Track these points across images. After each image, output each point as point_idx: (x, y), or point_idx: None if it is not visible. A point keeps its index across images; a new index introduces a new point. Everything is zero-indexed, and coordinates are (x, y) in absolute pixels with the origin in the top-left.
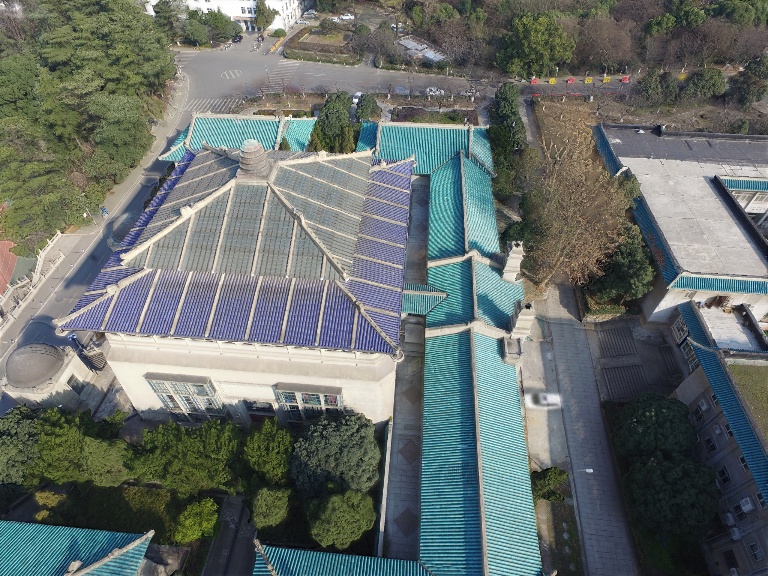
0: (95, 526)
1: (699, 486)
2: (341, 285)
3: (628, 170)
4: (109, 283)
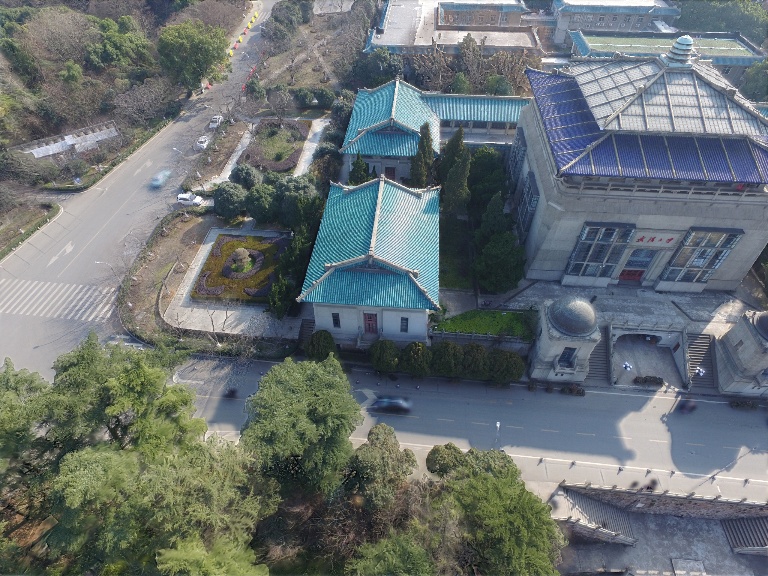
0: None
1: None
2: None
3: (439, 44)
4: None
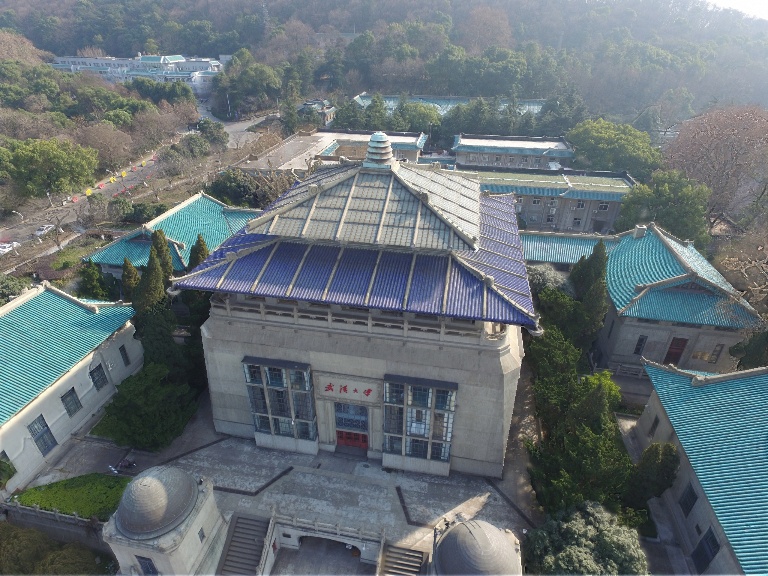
0: None
1: None
2: None
3: (296, 169)
4: (471, 295)
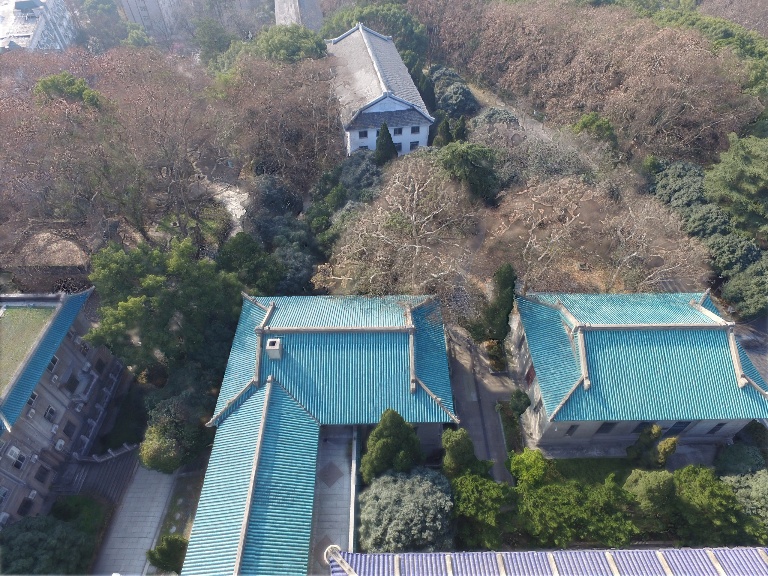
0: (622, 465)
1: (5, 547)
2: None
3: None
4: None
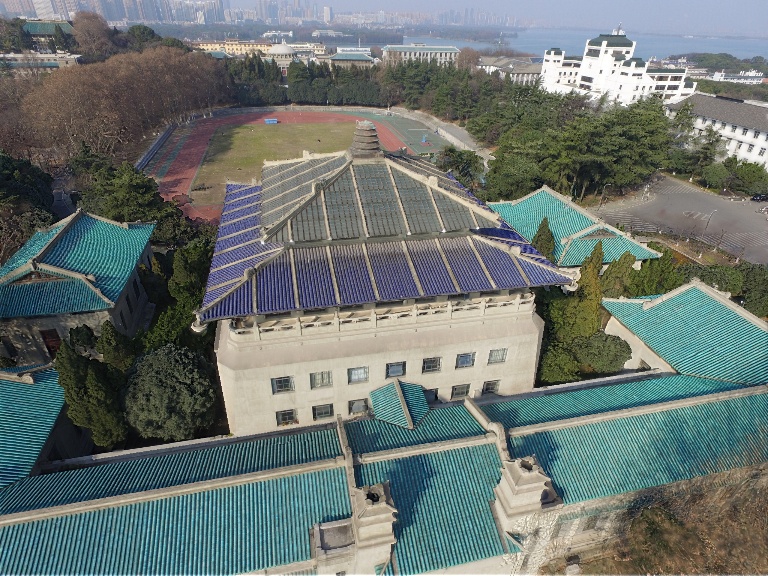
0: (161, 311)
1: None
2: (275, 255)
3: None
4: None
